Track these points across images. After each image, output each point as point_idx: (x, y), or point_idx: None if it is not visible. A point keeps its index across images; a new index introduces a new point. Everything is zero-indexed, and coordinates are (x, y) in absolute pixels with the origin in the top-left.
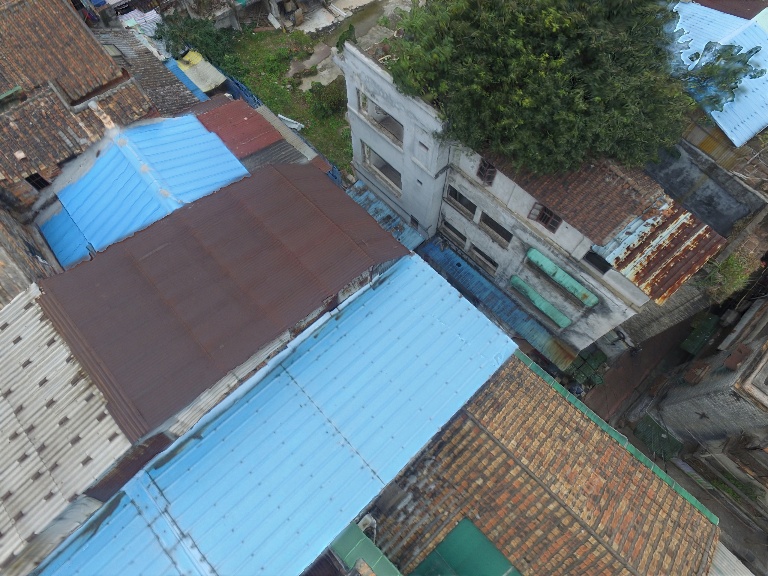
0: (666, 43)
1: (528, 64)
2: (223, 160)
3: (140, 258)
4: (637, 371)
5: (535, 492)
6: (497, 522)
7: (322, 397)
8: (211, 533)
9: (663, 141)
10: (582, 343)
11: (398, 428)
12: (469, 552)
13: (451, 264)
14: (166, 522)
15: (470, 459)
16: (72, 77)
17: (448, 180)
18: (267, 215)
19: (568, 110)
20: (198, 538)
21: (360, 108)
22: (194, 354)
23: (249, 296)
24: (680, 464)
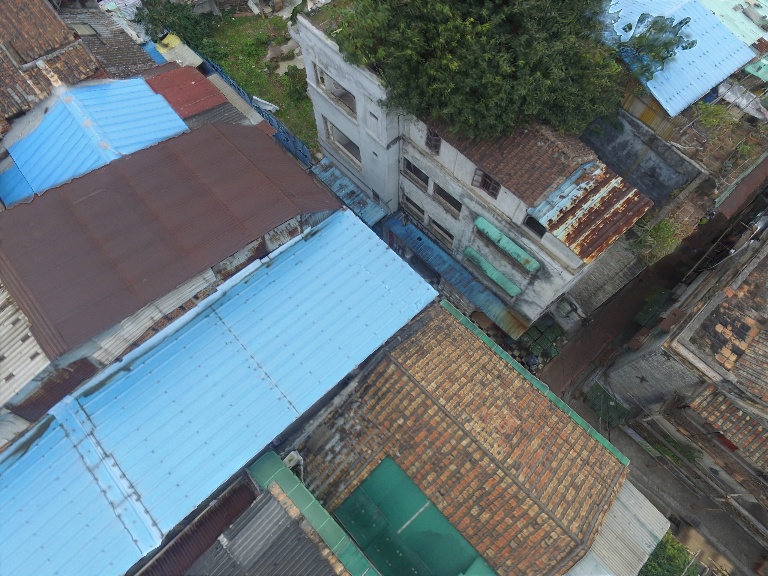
0: (594, 12)
1: (455, 28)
2: (166, 119)
3: (75, 202)
4: (594, 345)
5: (450, 429)
6: (415, 459)
7: (247, 336)
8: (132, 454)
9: (593, 107)
10: (532, 312)
11: (317, 364)
12: (391, 489)
13: (412, 238)
14: (91, 443)
15: (392, 400)
16: (25, 40)
17: (402, 152)
18: (201, 167)
19: (497, 74)
20: (120, 458)
21: (318, 82)
22: (117, 286)
23: (176, 238)
24: (630, 433)
